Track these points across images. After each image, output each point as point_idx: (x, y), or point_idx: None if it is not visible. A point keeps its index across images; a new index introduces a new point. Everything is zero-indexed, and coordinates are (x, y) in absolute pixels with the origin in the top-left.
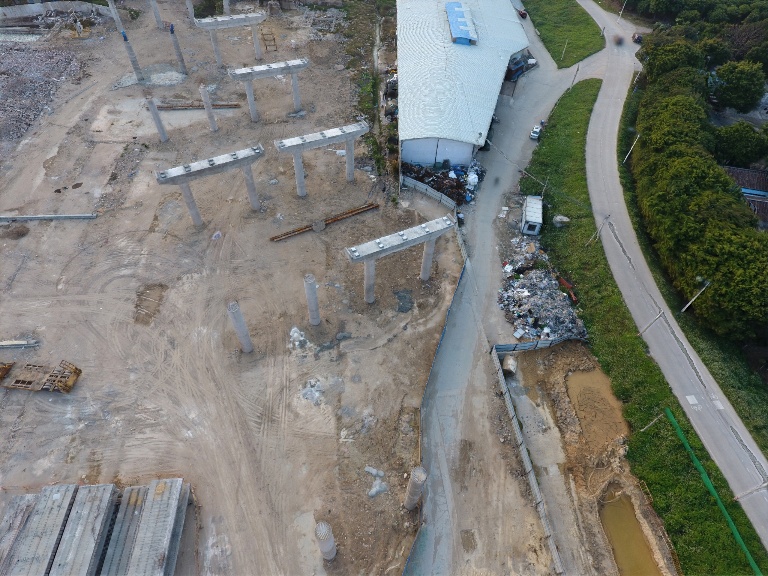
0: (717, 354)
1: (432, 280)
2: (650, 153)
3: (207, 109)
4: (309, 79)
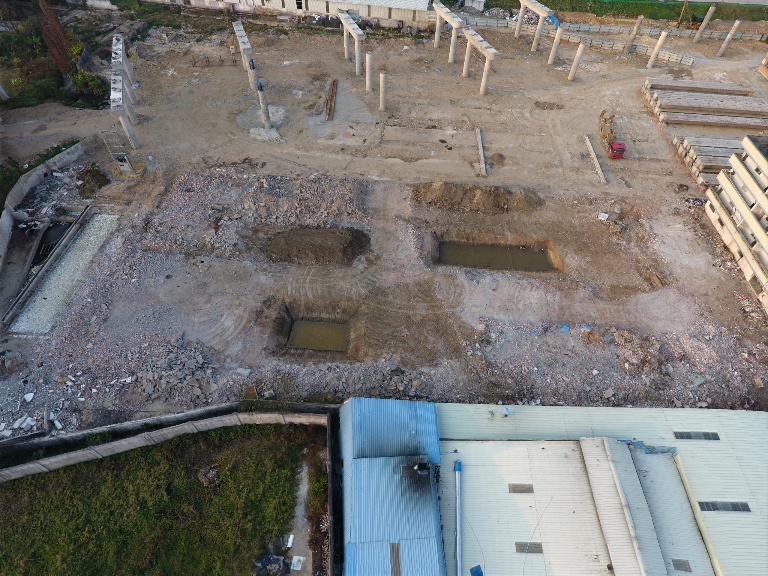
0: None
1: None
2: None
3: None
4: (298, 51)
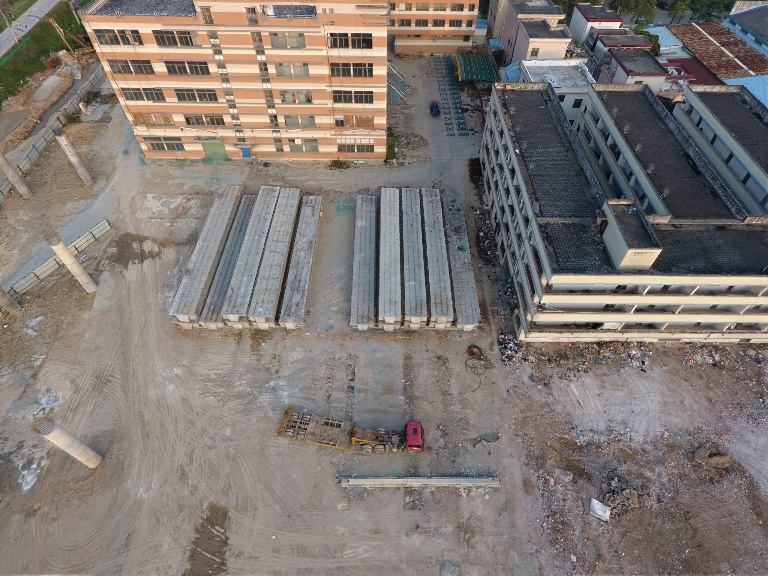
0: None
1: None
2: None
3: None
4: None
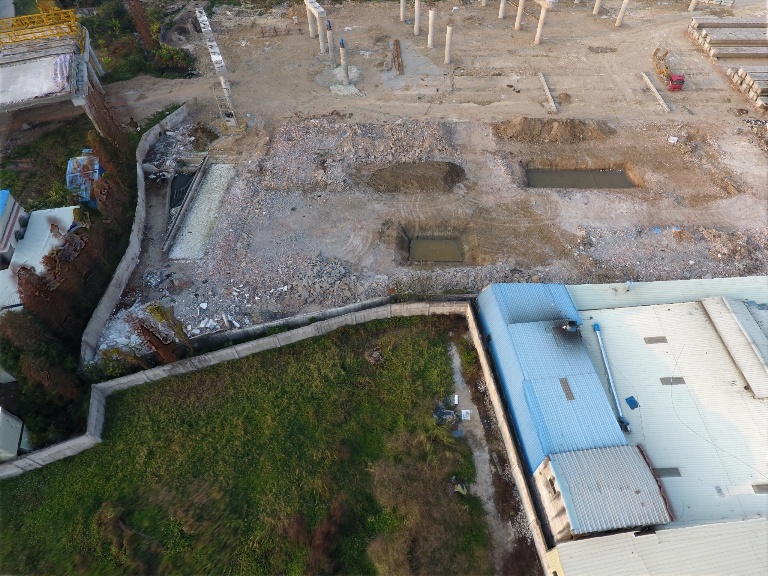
0: None
1: None
2: None
3: None
4: (355, 18)
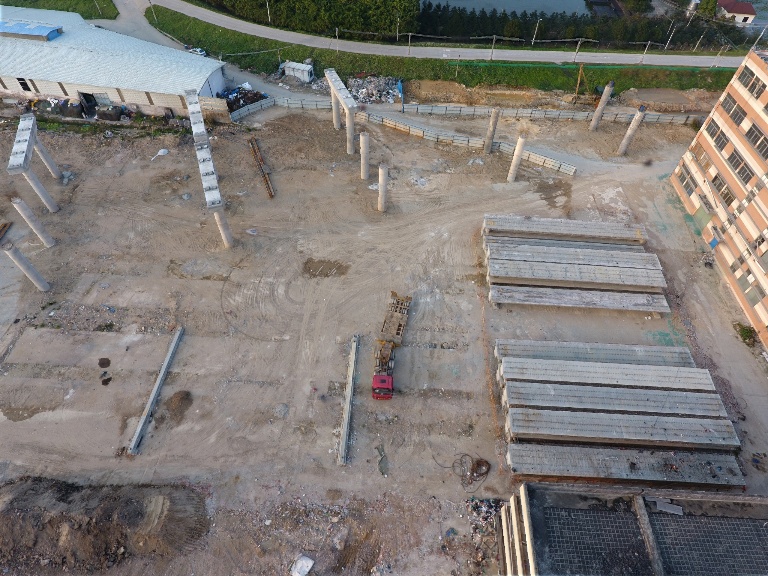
0: (422, 42)
1: (341, 124)
2: (275, 6)
3: (37, 223)
4: None
